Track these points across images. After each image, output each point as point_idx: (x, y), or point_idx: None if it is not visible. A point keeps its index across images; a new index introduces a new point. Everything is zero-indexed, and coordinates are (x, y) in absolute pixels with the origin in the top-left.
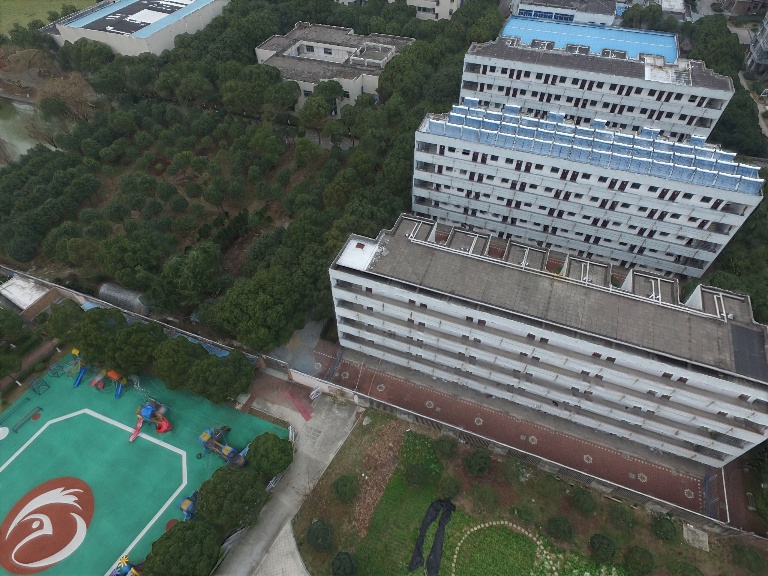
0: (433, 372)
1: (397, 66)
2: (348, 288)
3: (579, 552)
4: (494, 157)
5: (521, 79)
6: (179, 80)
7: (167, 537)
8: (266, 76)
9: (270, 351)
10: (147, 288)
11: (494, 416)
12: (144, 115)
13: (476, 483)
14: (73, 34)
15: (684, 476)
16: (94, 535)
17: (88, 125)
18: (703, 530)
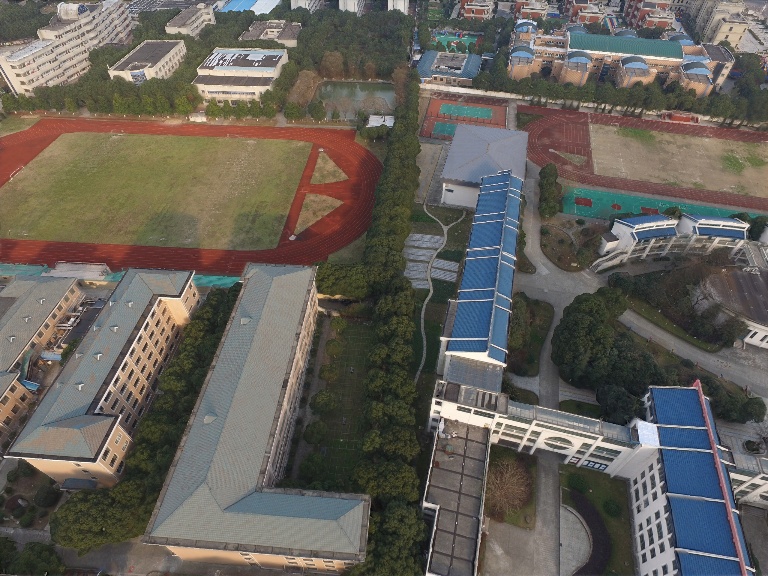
0: None
1: None
2: None
3: None
4: None
5: None
6: None
7: None
8: None
9: None
10: None
11: None
12: None
13: None
14: (276, 71)
15: (409, 9)
16: None
17: None
18: (417, 8)
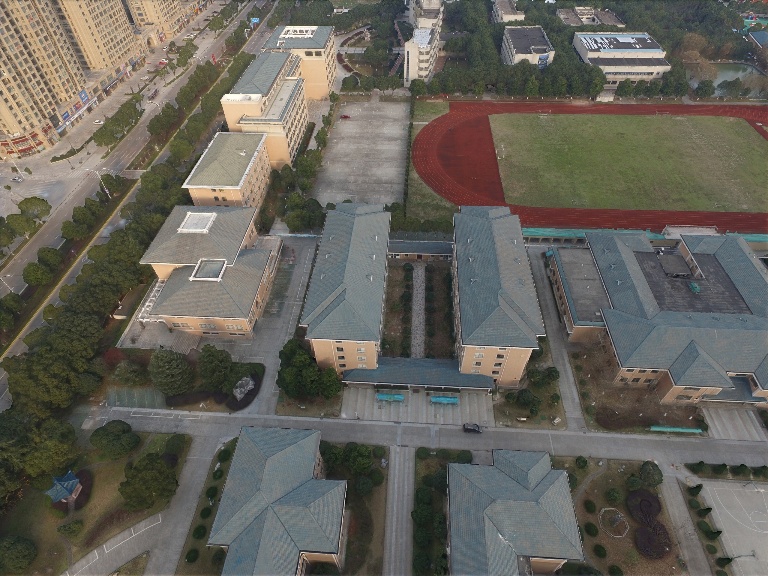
0: None
1: (598, 1)
2: None
3: None
4: None
5: None
6: None
7: (745, 5)
8: None
9: None
10: None
11: None
12: None
13: None
14: None
15: None
16: None
17: None
18: None
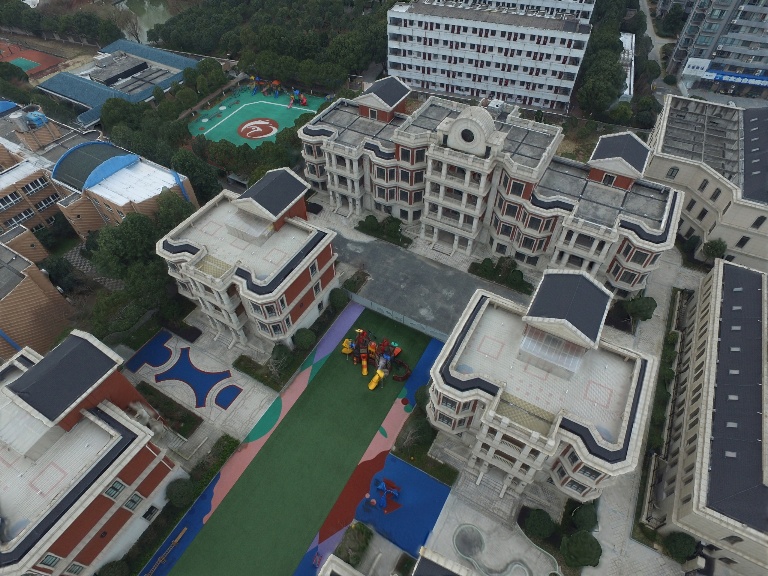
0: (436, 79)
1: None
2: (395, 25)
3: None
4: None
5: None
6: None
7: None
8: None
9: (354, 71)
10: (285, 51)
11: None
12: None
13: None
14: None
15: None
16: None
17: None
18: (559, 125)
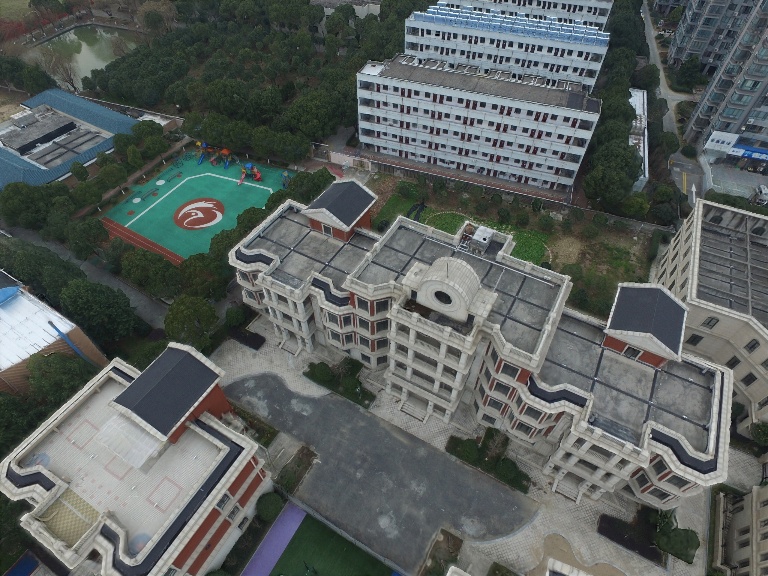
0: (415, 150)
1: None
2: (367, 89)
3: (492, 221)
4: (455, 36)
5: (478, 1)
6: (236, 5)
7: None
8: (300, 1)
9: (318, 139)
10: None
11: (451, 176)
12: (211, 30)
13: (438, 197)
14: None
15: (556, 197)
16: (227, 217)
17: (175, 33)
18: (560, 214)
